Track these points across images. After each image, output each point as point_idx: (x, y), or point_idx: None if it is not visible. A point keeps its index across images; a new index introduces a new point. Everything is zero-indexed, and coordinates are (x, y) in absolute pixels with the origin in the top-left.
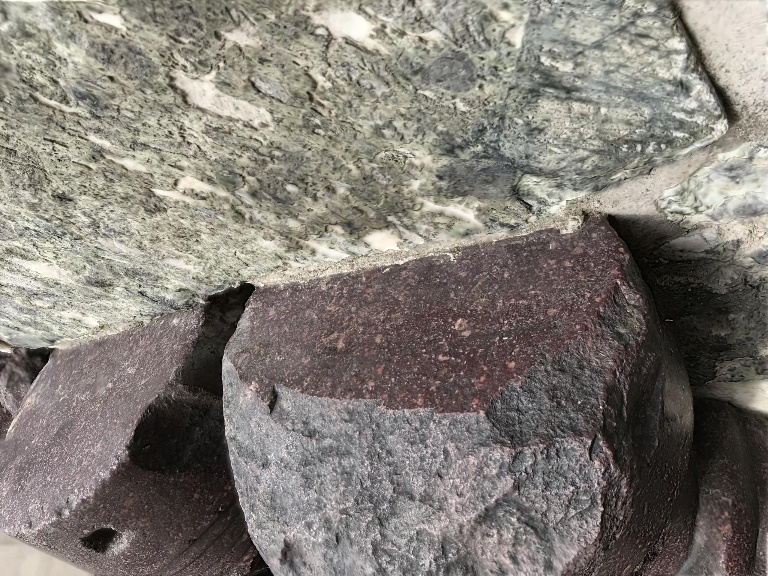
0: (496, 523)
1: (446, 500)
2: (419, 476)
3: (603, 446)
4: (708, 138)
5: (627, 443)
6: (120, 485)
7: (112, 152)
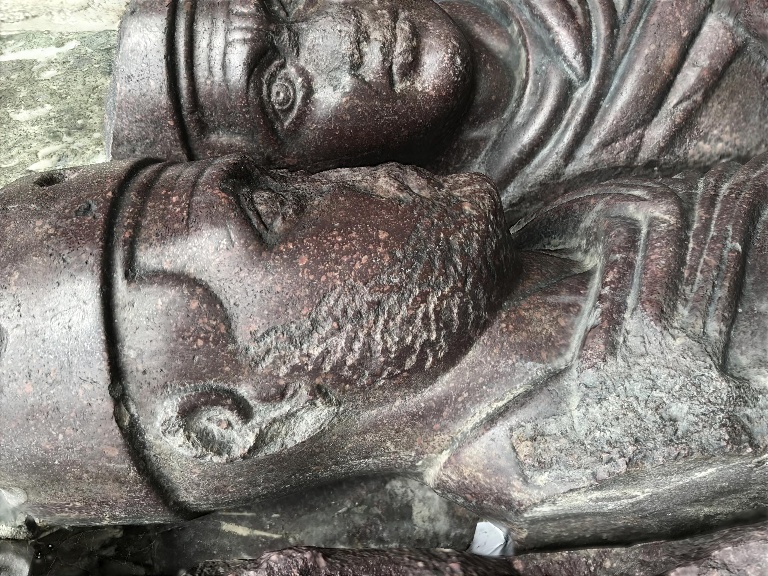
0: None
1: None
2: None
3: None
4: None
5: None
6: None
7: (3, 162)
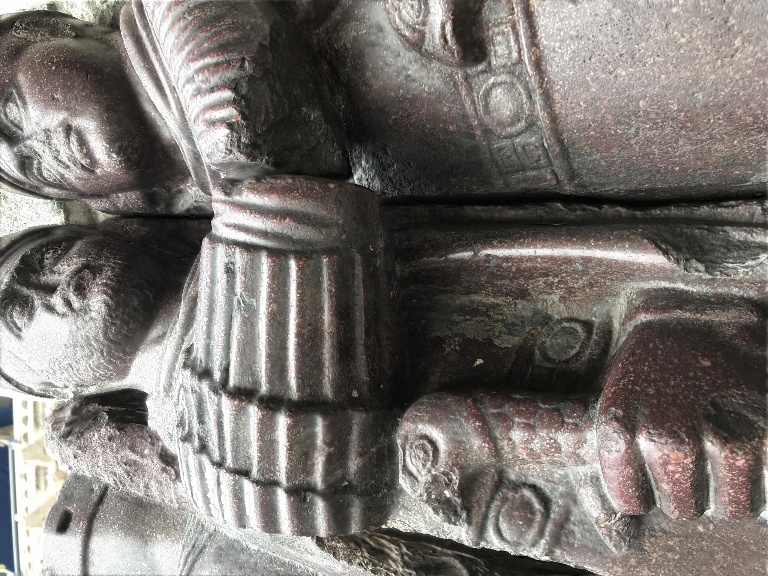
0: None
1: None
2: None
3: None
4: (45, 8)
5: None
6: None
7: None
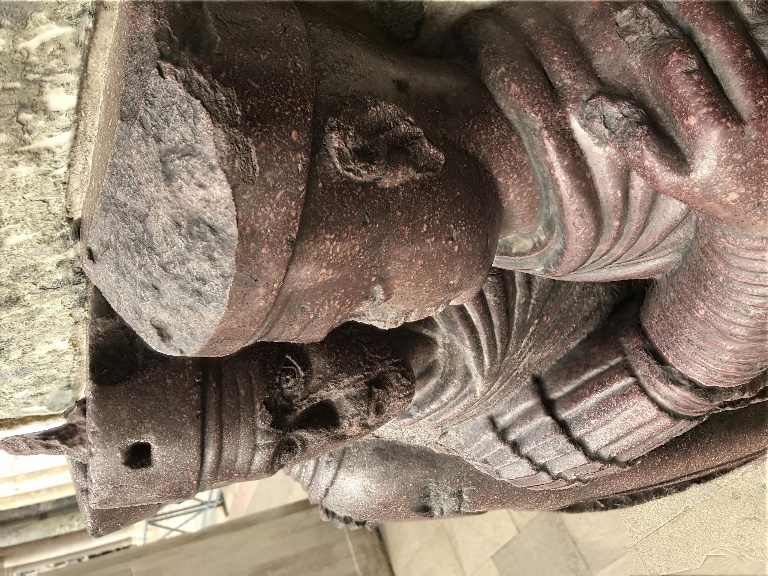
0: (176, 175)
1: (151, 193)
2: (137, 197)
3: (165, 65)
4: None
5: (184, 51)
6: (106, 406)
7: None
